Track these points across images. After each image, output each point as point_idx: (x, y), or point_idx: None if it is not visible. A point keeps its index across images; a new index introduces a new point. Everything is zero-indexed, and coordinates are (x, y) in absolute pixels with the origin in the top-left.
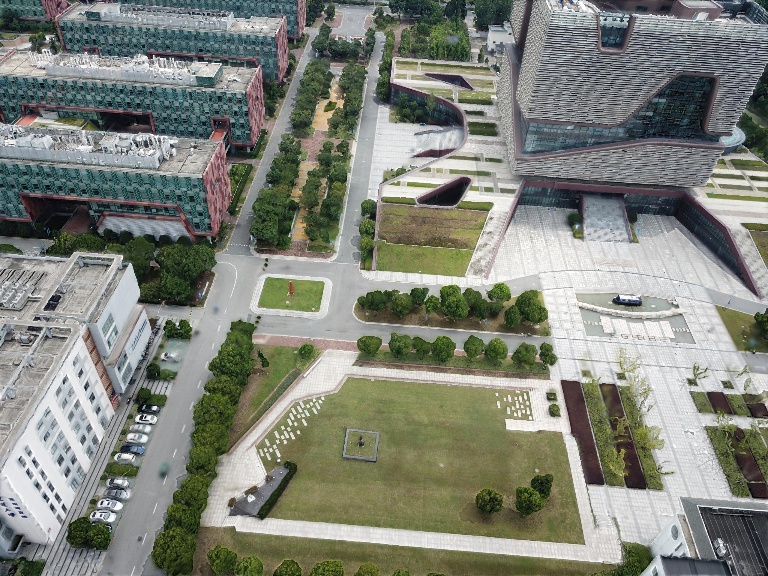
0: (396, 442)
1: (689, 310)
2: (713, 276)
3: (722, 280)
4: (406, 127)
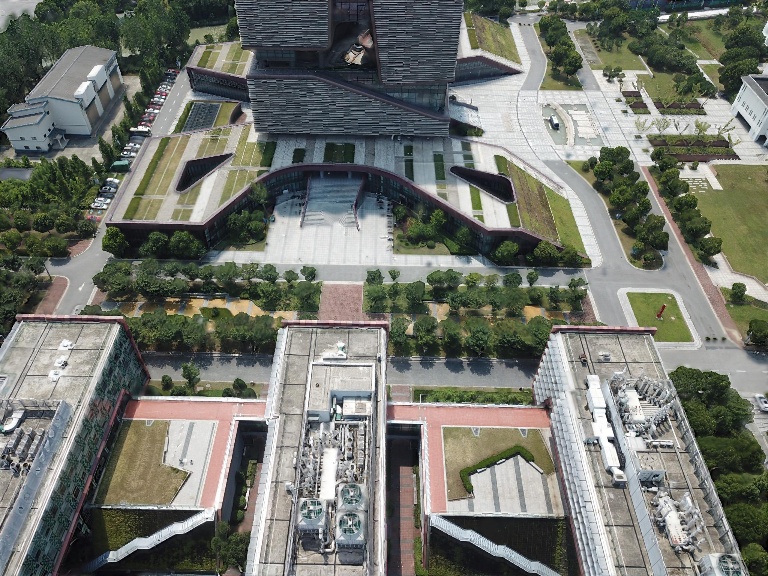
0: None
1: (551, 100)
2: (505, 84)
3: (509, 82)
4: (279, 235)
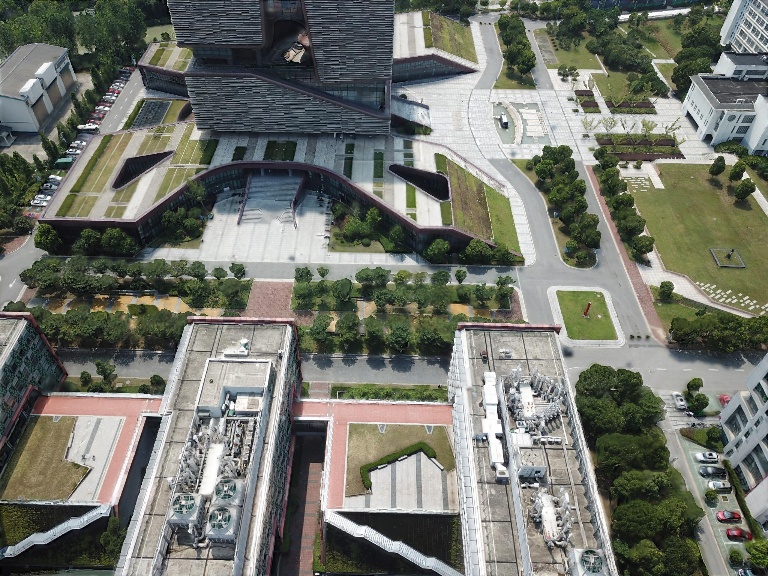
0: (711, 240)
1: (503, 99)
2: (459, 83)
3: (463, 81)
4: (216, 232)
